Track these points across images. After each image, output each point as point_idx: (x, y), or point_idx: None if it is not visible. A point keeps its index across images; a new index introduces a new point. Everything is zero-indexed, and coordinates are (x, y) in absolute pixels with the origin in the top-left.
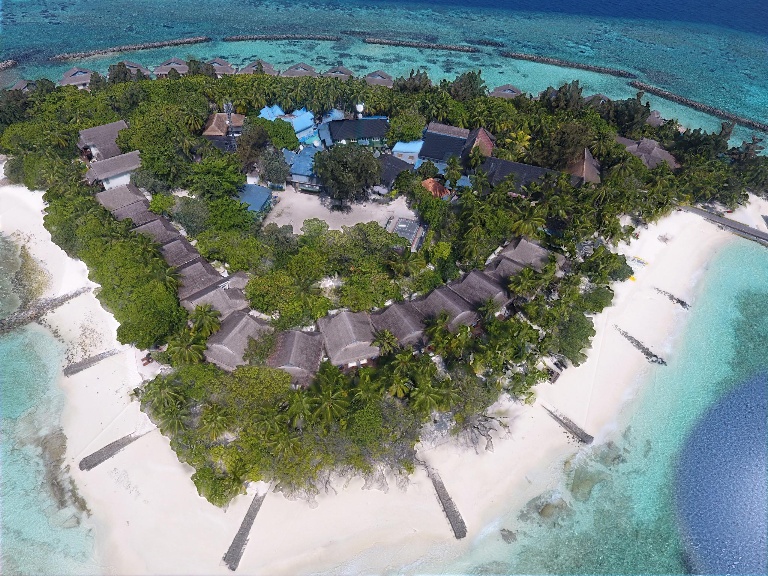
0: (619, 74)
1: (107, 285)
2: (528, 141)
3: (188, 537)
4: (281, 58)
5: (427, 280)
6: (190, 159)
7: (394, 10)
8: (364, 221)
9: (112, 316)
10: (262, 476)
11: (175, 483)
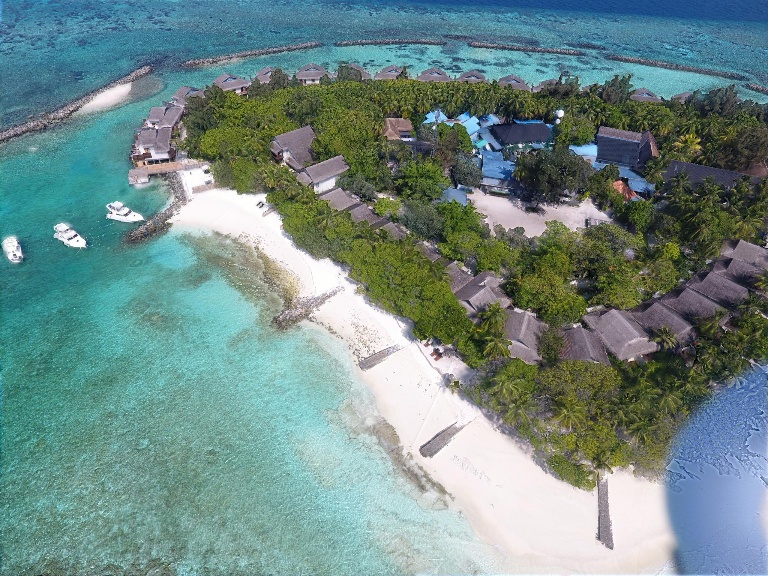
0: (731, 76)
1: (381, 284)
2: (696, 144)
3: (555, 519)
4: (399, 62)
5: (674, 279)
6: (385, 163)
7: (482, 14)
8: (563, 222)
9: (378, 314)
10: (623, 462)
11: (518, 469)
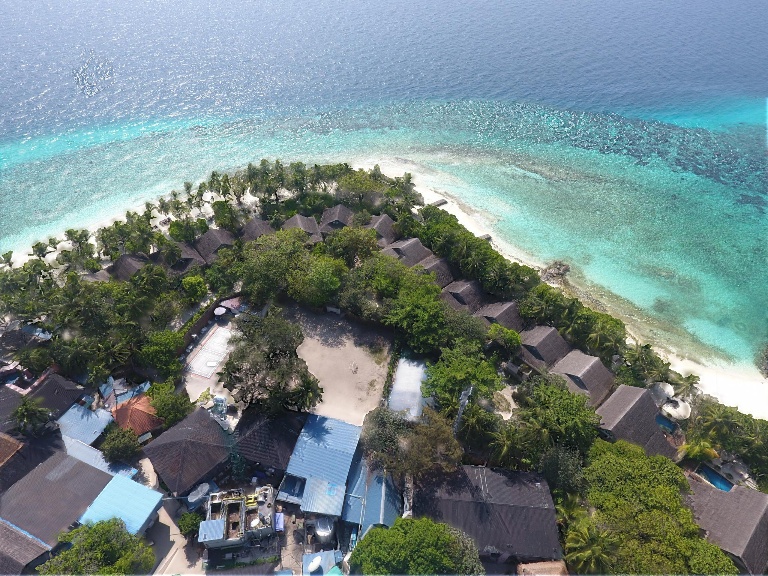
0: None
1: None
2: None
3: None
4: None
5: None
6: None
7: None
8: None
9: None
10: None
11: None
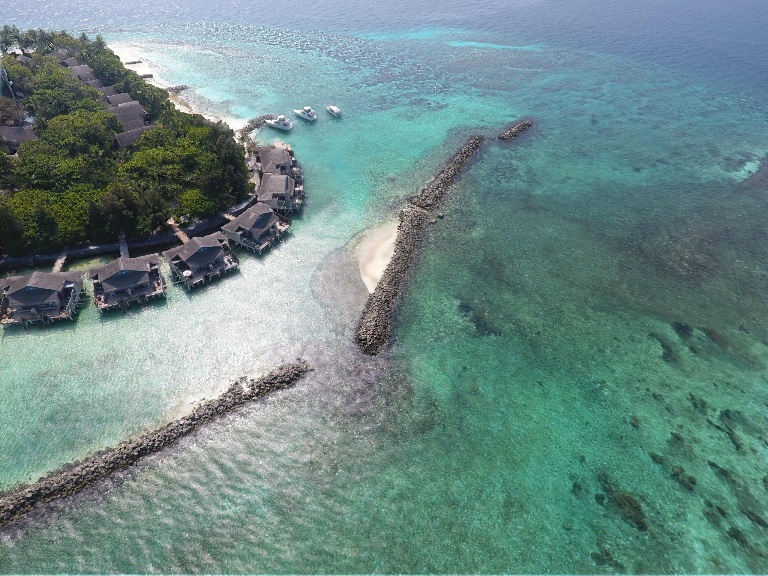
0: None
1: None
2: None
3: None
4: None
5: None
6: None
7: None
8: None
9: None
10: None
11: None
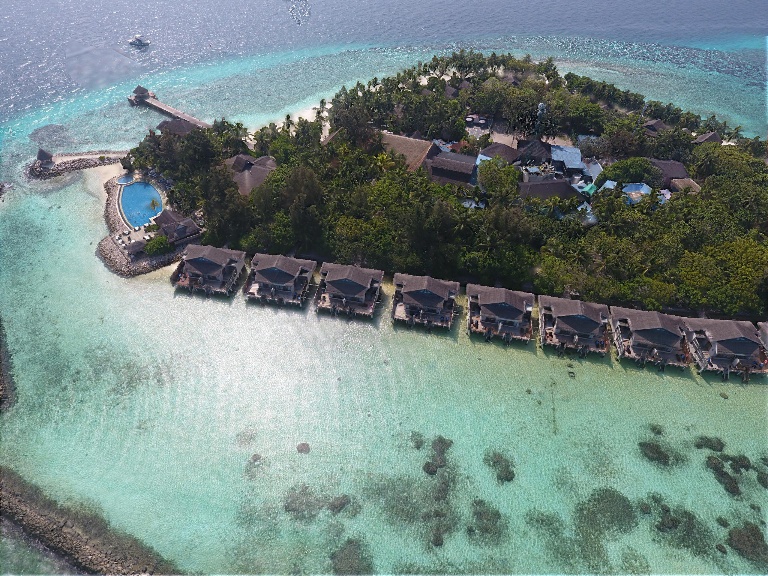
0: None
1: None
2: None
3: None
4: None
5: None
6: None
7: None
8: (505, 142)
9: None
10: None
11: None
